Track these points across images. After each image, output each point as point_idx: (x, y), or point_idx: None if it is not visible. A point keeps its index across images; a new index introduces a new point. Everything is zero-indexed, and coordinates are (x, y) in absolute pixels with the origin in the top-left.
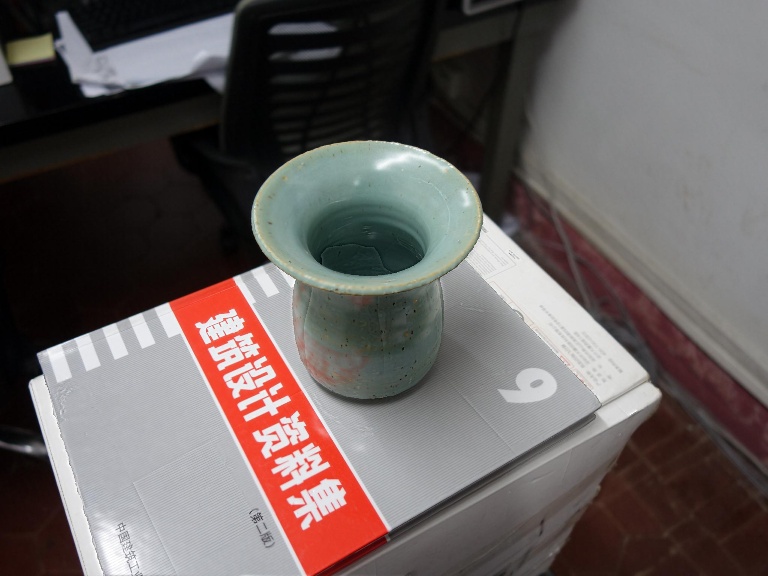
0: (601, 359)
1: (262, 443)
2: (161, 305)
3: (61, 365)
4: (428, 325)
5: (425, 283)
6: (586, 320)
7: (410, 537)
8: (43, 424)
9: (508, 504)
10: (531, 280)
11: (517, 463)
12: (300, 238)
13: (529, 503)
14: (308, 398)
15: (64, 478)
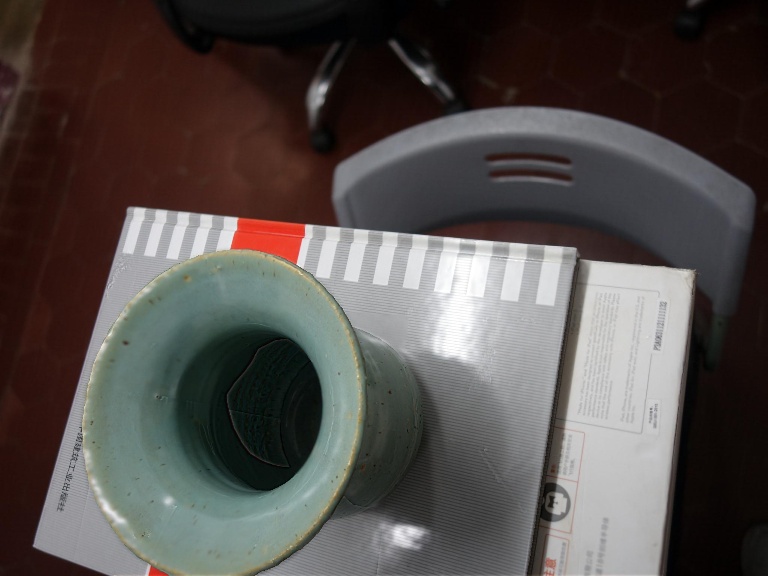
0: None
1: None
2: (231, 217)
3: (133, 234)
4: None
5: None
6: None
7: None
8: None
9: None
10: (635, 473)
11: None
12: (170, 365)
13: None
14: None
15: None
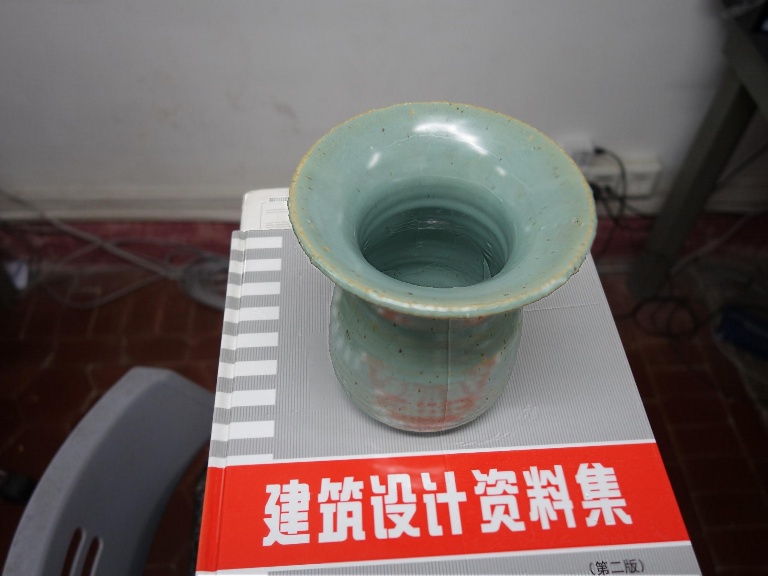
0: None
1: (502, 526)
2: None
3: None
4: None
5: None
6: None
7: None
8: None
9: None
10: None
11: None
12: None
13: None
14: (459, 452)
15: None
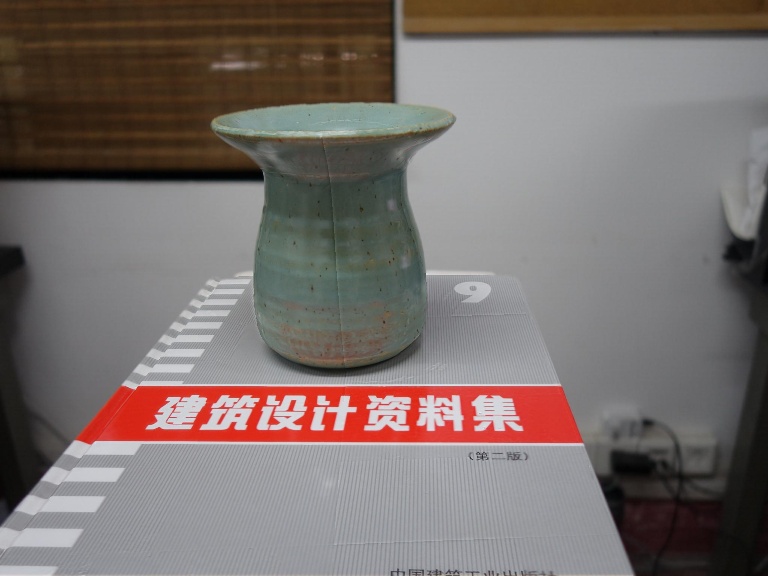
0: None
1: (385, 427)
2: None
3: (14, 573)
4: None
5: None
6: None
7: None
8: None
9: None
10: None
11: None
12: None
13: None
14: (360, 385)
15: None
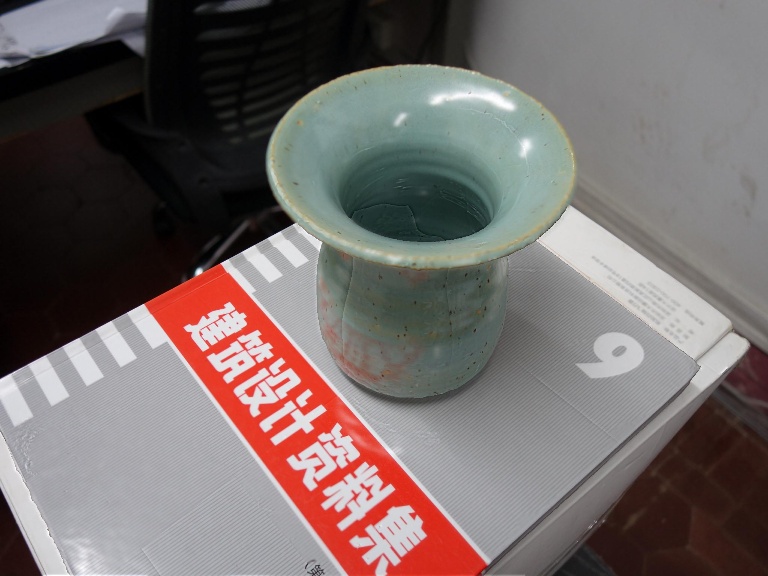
0: (677, 312)
1: (302, 471)
2: None
3: (15, 402)
4: (500, 296)
5: (529, 242)
6: (648, 268)
7: (503, 562)
8: (2, 482)
9: (599, 498)
10: (574, 228)
11: (614, 451)
12: (334, 200)
13: (616, 491)
14: (347, 404)
15: (43, 552)
